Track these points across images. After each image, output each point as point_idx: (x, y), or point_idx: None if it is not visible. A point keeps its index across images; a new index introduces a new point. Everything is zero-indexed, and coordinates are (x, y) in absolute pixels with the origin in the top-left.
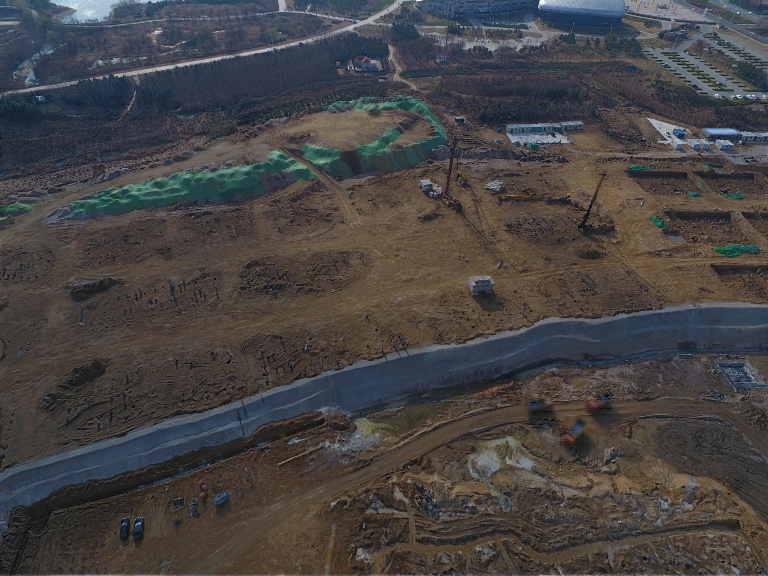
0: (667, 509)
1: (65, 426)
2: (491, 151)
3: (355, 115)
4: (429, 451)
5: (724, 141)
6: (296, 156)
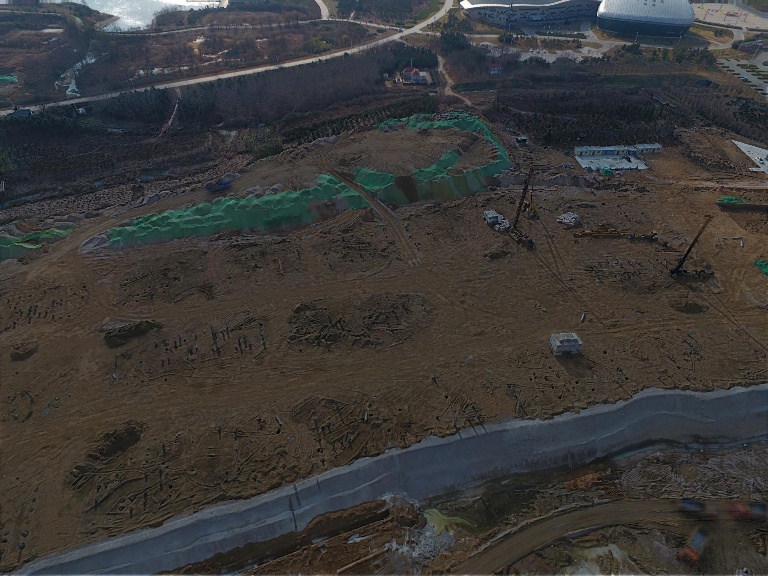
0: None
1: (93, 509)
2: (560, 177)
3: (409, 134)
4: (516, 560)
5: None
6: (346, 180)
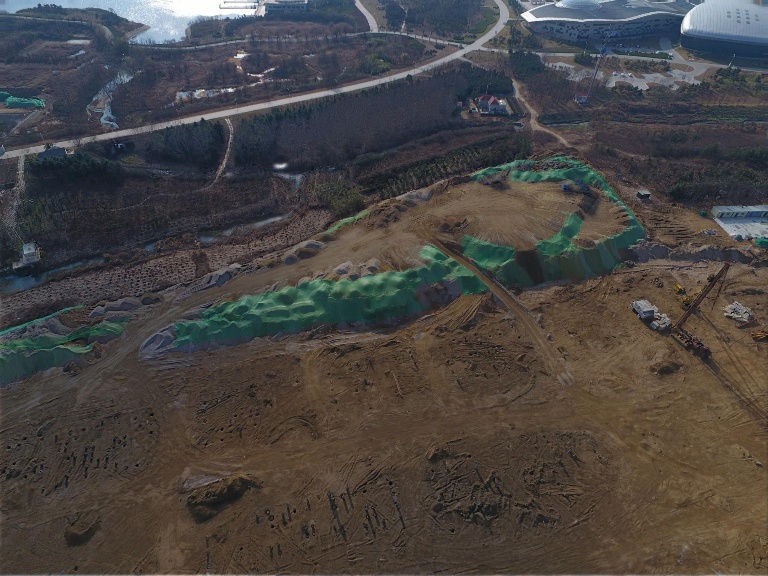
0: None
1: None
2: (709, 250)
3: (514, 189)
4: None
5: None
6: (454, 253)
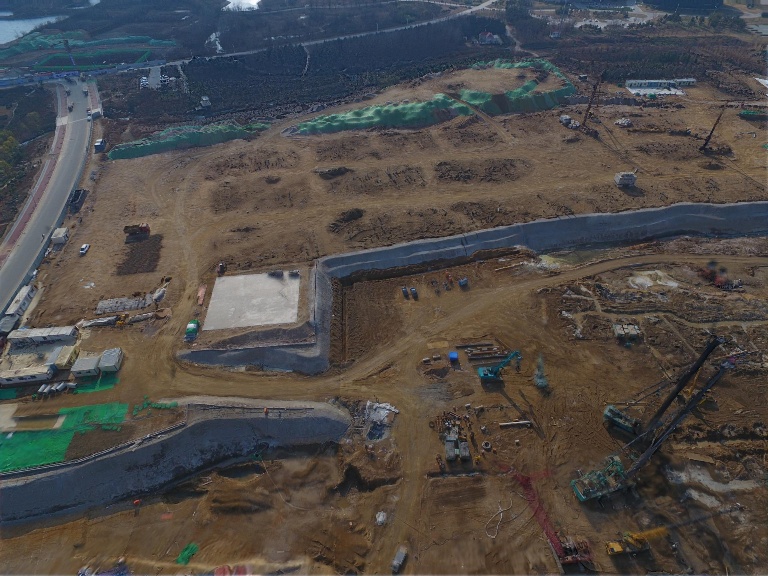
0: None
1: (350, 240)
2: (615, 99)
3: (496, 71)
4: (599, 273)
5: None
6: (455, 98)
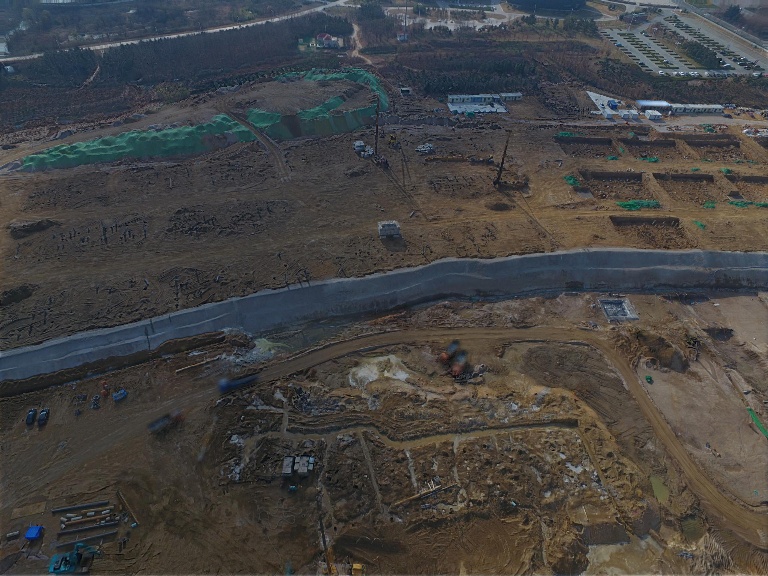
0: (515, 410)
1: None
2: (428, 118)
3: (303, 84)
4: (316, 364)
5: (653, 111)
6: (240, 120)
